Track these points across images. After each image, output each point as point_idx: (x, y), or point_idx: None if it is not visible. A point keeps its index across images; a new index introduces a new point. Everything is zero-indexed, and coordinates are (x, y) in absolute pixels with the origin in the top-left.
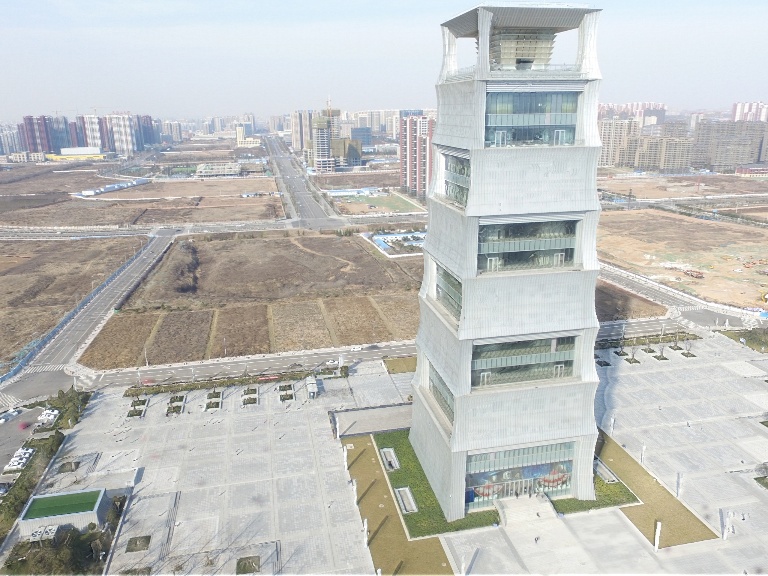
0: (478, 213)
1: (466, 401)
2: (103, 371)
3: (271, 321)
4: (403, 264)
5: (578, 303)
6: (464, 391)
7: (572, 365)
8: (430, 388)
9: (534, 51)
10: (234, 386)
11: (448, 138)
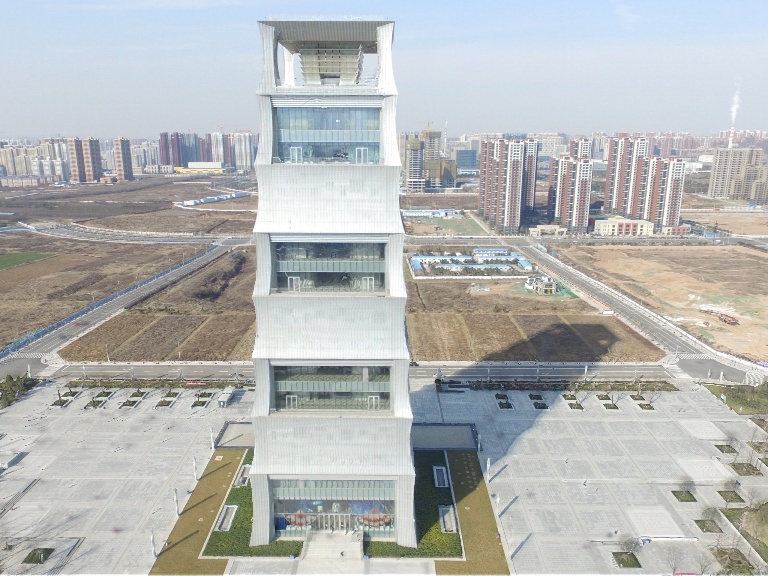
0: (266, 230)
1: (263, 422)
2: (70, 362)
3: (250, 331)
4: (421, 286)
5: (386, 331)
6: (261, 412)
7: (389, 398)
8: None
9: (339, 66)
10: (162, 388)
11: None
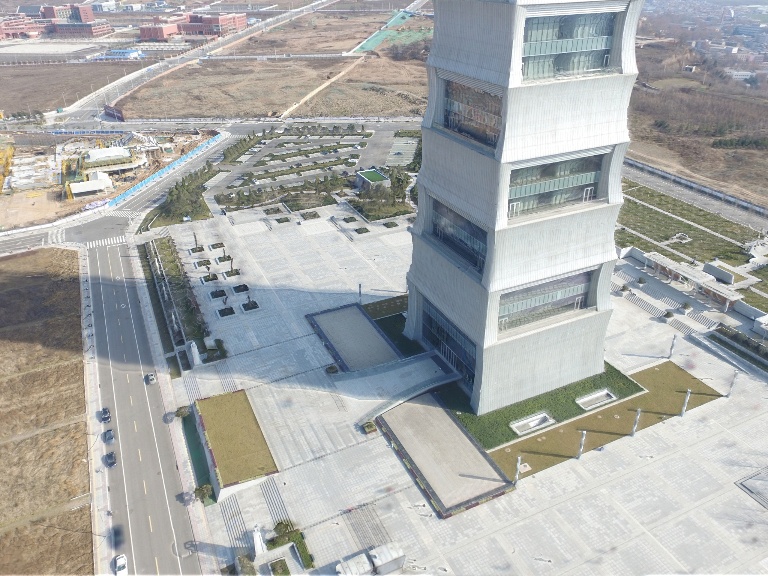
0: None
1: None
2: None
3: None
4: None
5: None
6: None
7: None
8: (499, 329)
9: None
10: None
11: None
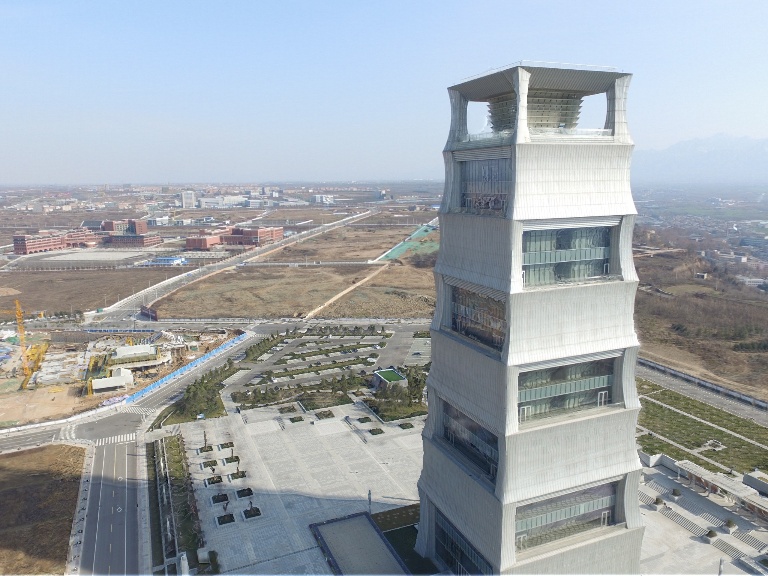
0: None
1: None
2: None
3: None
4: None
5: None
6: None
7: None
8: (518, 548)
9: None
10: None
11: (573, 208)
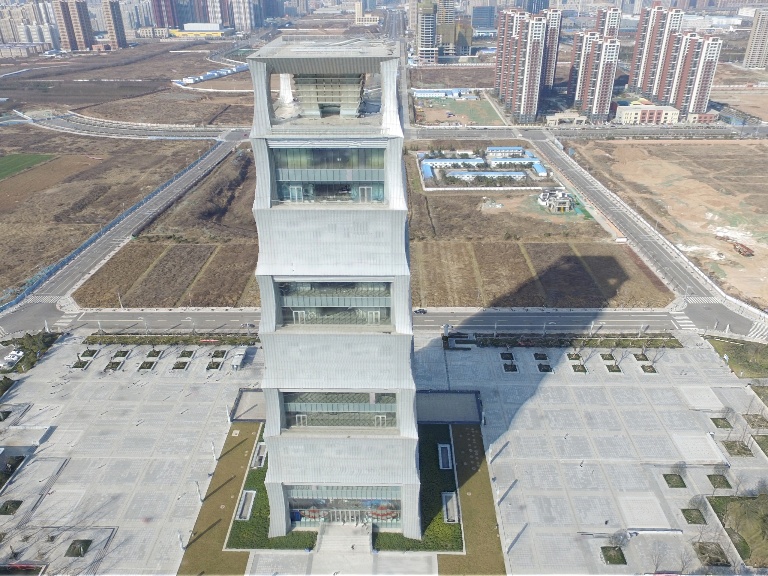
0: (268, 272)
1: (275, 441)
2: (85, 309)
3: None
4: (431, 201)
5: (392, 363)
6: (273, 432)
7: (395, 417)
8: None
9: (339, 95)
10: (177, 345)
11: None
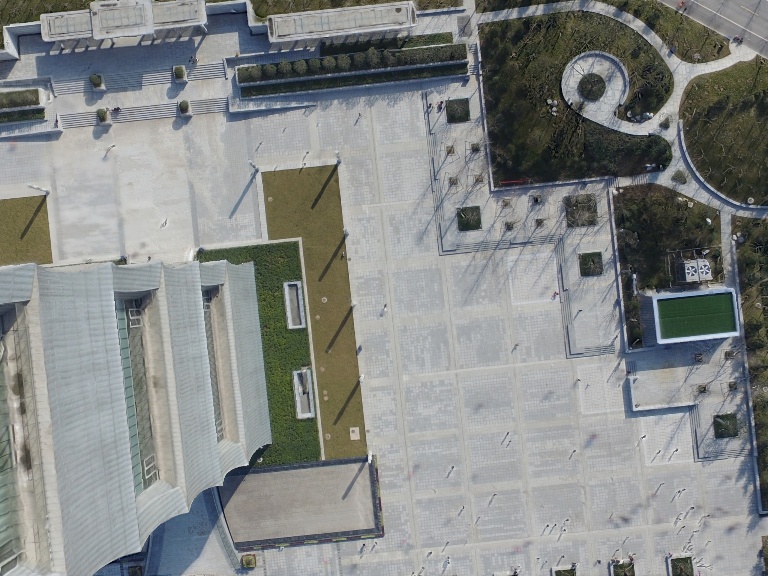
0: None
1: None
2: None
3: None
4: None
5: None
6: None
7: None
8: None
9: None
10: None
11: None
